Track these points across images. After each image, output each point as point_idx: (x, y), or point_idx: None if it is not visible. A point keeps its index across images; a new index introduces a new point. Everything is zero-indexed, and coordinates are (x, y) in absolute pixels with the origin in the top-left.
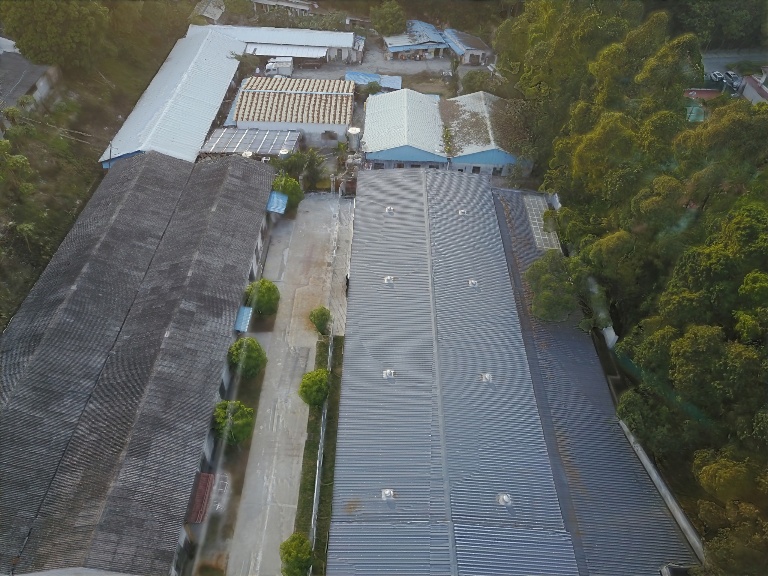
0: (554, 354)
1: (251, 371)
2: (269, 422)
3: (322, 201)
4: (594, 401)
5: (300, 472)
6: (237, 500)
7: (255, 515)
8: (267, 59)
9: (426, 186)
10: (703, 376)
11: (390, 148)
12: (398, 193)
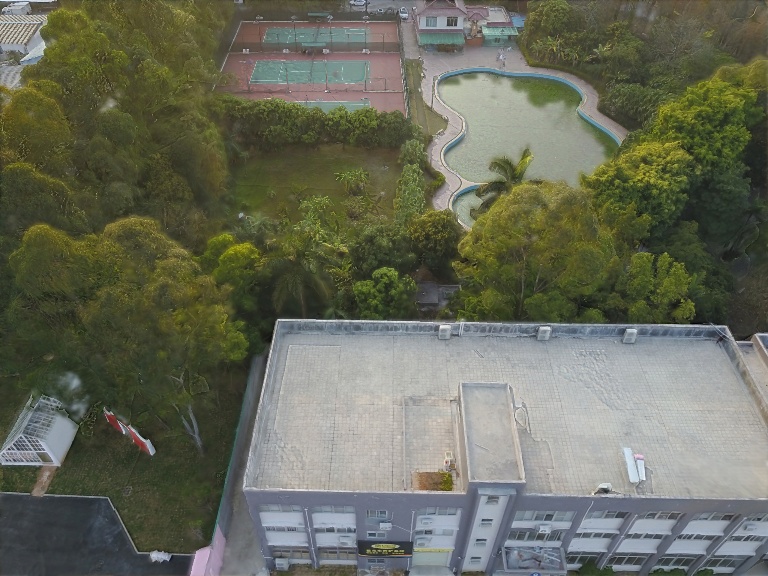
0: None
1: None
2: None
3: None
4: None
5: None
6: None
7: None
8: (8, 4)
9: None
10: None
11: (36, 57)
12: (0, 80)
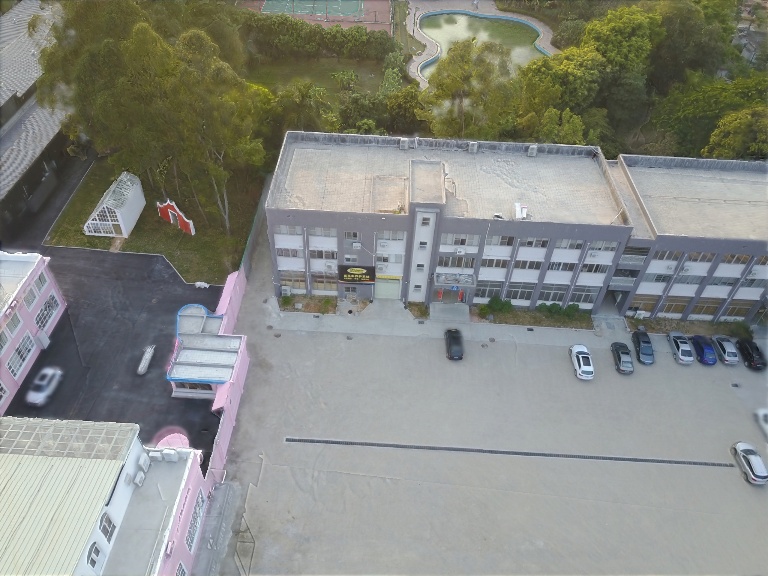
0: None
1: None
2: None
3: None
4: None
5: None
6: None
7: None
8: None
9: None
10: None
11: None
12: None
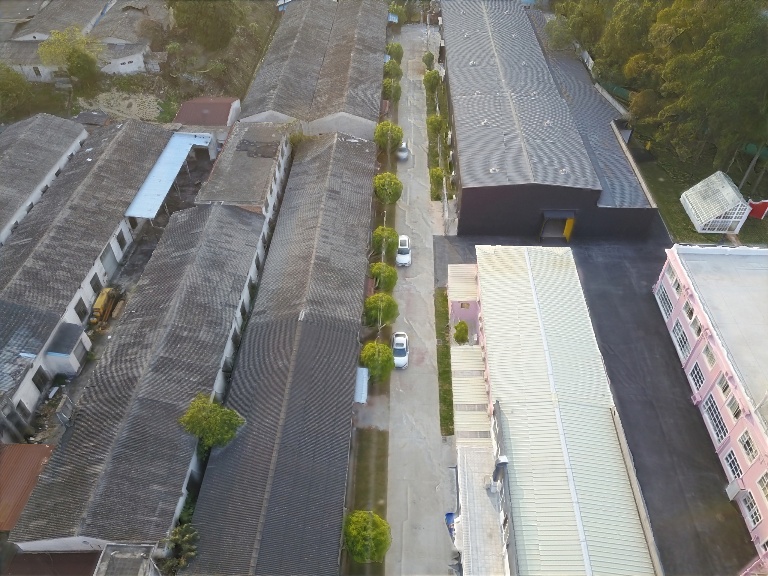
0: (561, 66)
1: (395, 77)
2: (406, 103)
3: (415, 28)
4: (582, 80)
5: (426, 118)
6: (396, 125)
7: (407, 129)
8: None
9: (484, 3)
10: (628, 26)
11: None
12: (467, 6)
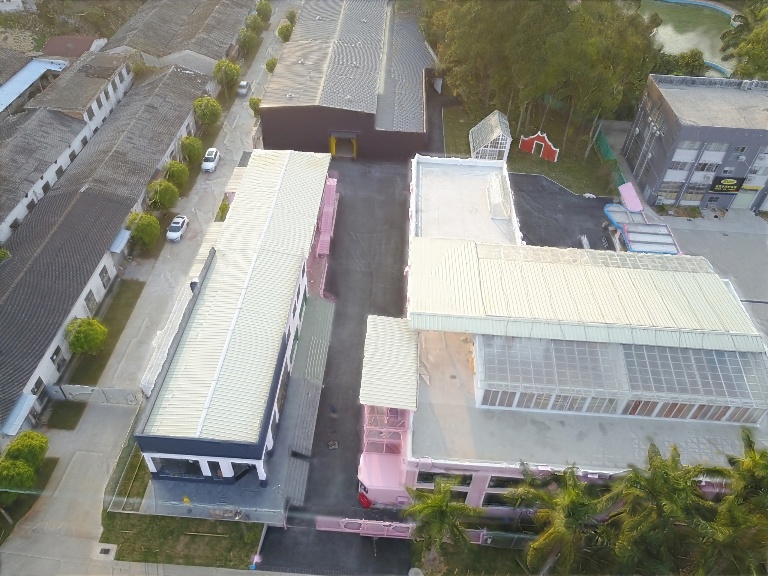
0: (403, 26)
1: (256, 29)
2: (264, 53)
3: None
4: (416, 38)
5: None
6: (248, 69)
7: (256, 72)
8: None
9: None
10: None
11: None
12: None
